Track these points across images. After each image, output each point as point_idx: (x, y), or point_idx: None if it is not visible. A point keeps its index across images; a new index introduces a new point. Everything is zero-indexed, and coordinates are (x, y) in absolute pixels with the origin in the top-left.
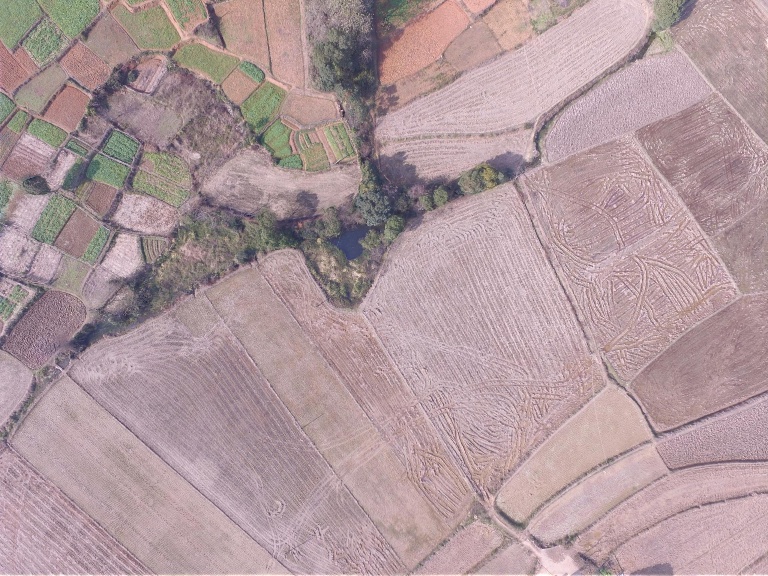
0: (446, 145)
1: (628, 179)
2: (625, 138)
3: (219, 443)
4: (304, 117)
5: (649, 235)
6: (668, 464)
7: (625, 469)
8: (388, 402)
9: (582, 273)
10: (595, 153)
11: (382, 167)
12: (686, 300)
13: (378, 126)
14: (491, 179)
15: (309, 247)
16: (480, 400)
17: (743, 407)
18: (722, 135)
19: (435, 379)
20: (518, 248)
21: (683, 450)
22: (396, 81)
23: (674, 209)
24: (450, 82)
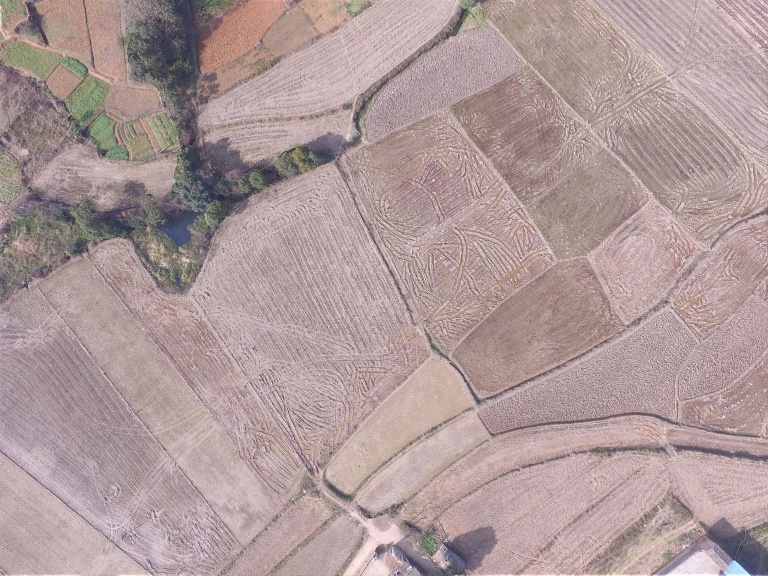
0: (268, 129)
1: (446, 153)
2: (441, 114)
3: (55, 432)
4: (128, 109)
5: (467, 207)
6: (490, 429)
7: (448, 437)
8: (219, 383)
9: (404, 247)
10: (413, 130)
11: (207, 154)
12: (505, 269)
13: (201, 114)
14: (302, 159)
15: (139, 236)
16: (308, 377)
17: (561, 370)
18: (534, 106)
19: (264, 358)
20: (341, 226)
21: (504, 415)
22: (216, 69)
23: (491, 180)
24: (269, 67)
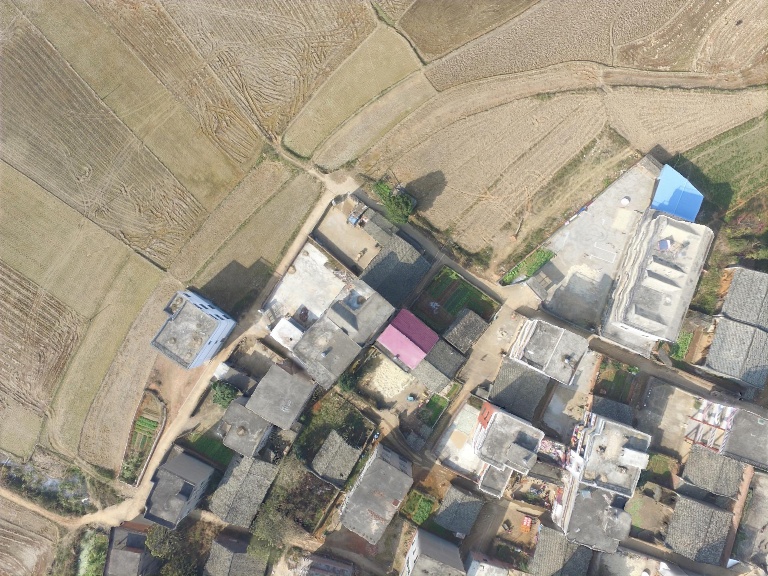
0: None
1: None
2: None
3: (27, 122)
4: None
5: None
6: (436, 87)
7: (397, 96)
8: (179, 67)
9: None
10: None
11: None
12: None
13: None
14: None
15: None
16: (263, 55)
17: (501, 27)
18: None
19: (221, 41)
20: None
21: (449, 73)
22: None
23: None
24: None
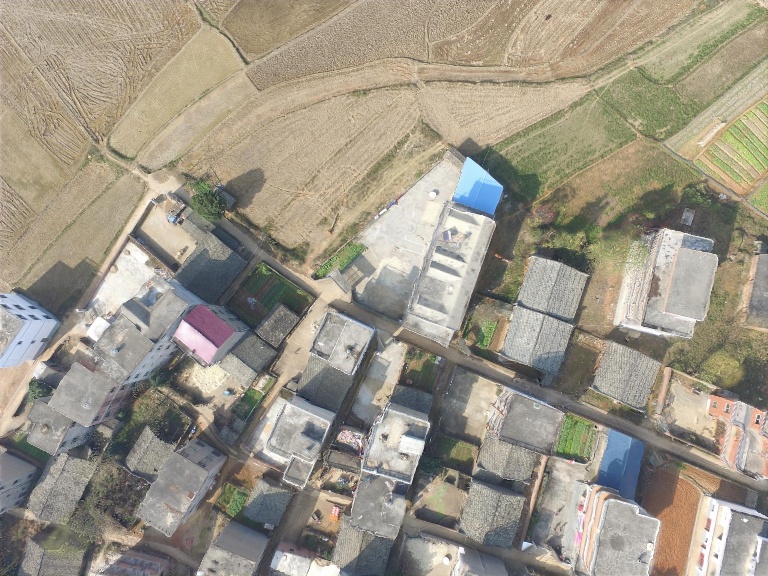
0: None
1: None
2: None
3: None
4: None
5: None
6: (258, 86)
7: (220, 96)
8: (8, 72)
9: None
10: None
11: None
12: None
13: None
14: None
15: None
16: (90, 58)
17: (320, 26)
18: None
19: (49, 45)
20: None
21: (270, 72)
22: None
23: None
24: None
